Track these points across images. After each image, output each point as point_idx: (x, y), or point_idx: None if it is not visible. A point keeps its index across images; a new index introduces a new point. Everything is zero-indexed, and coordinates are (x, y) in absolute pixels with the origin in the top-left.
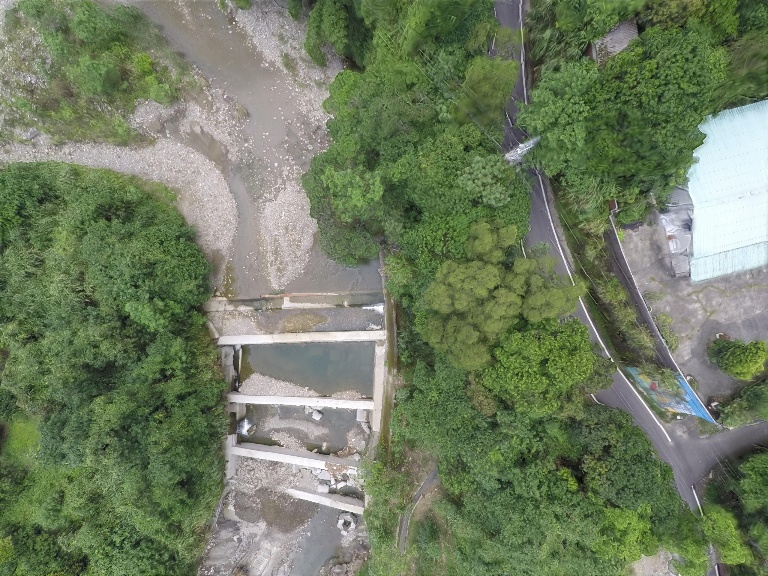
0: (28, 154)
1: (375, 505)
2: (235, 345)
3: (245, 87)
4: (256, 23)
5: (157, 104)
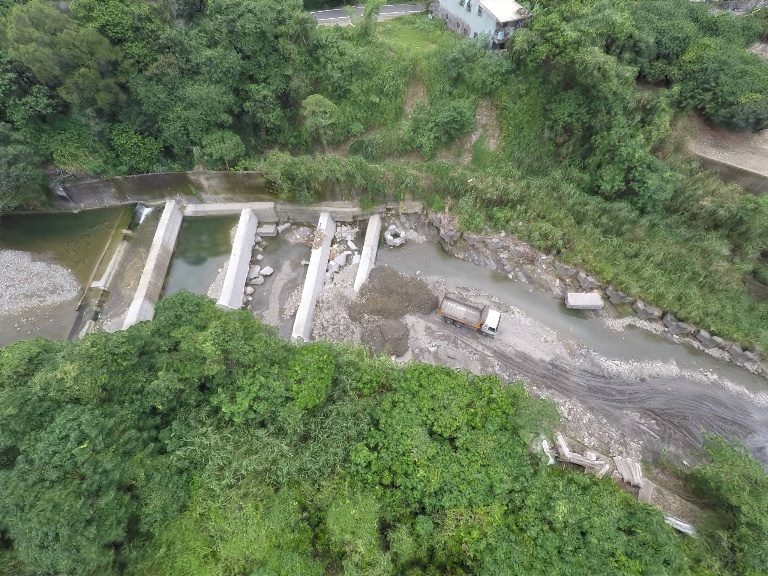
0: None
1: (322, 173)
2: None
3: None
4: None
5: None
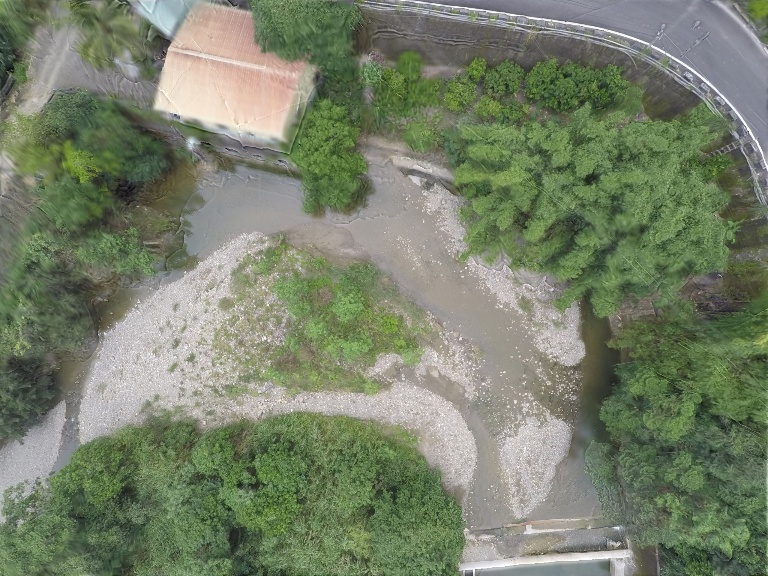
0: (260, 404)
1: None
2: None
3: (479, 328)
4: None
5: (397, 355)
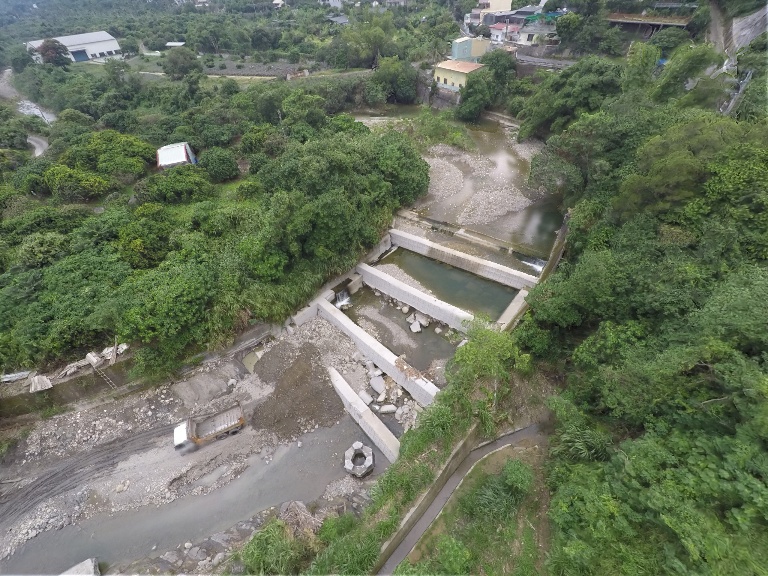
0: None
1: (455, 378)
2: (394, 245)
3: (502, 161)
4: (523, 149)
5: (450, 148)
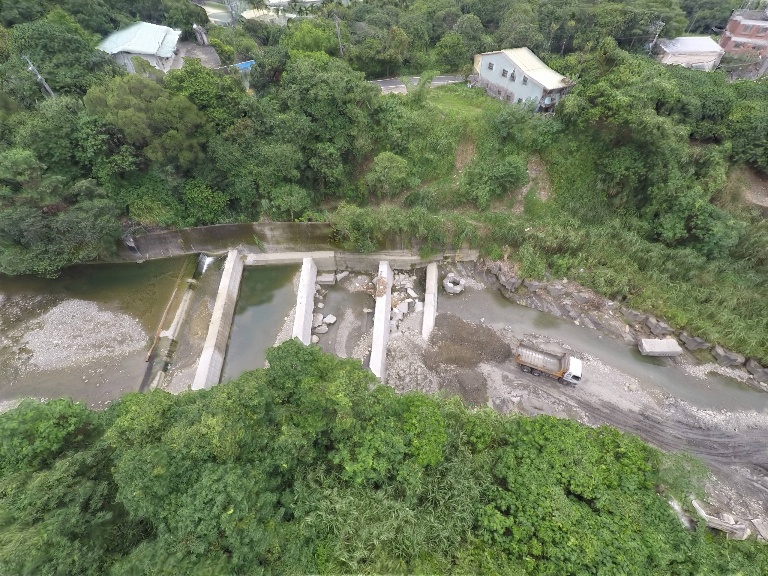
0: None
1: (386, 223)
2: None
3: None
4: None
5: None
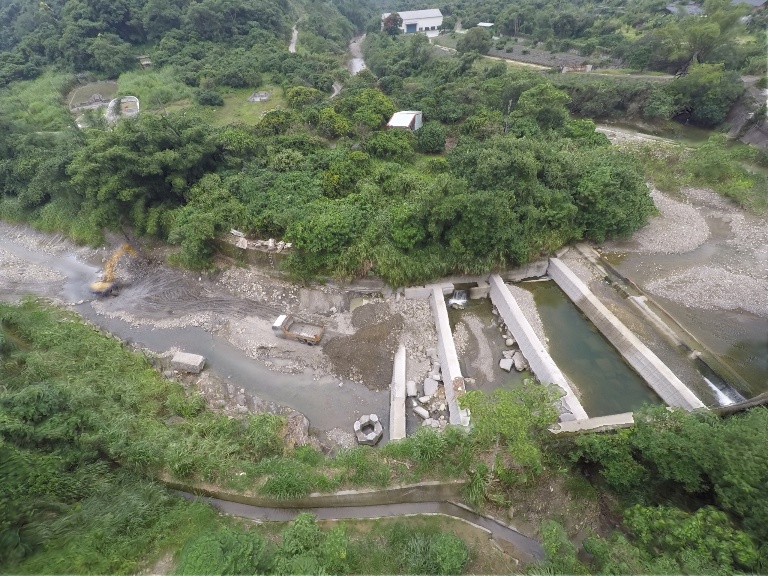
0: None
1: None
2: (548, 275)
3: None
4: None
5: (718, 198)
